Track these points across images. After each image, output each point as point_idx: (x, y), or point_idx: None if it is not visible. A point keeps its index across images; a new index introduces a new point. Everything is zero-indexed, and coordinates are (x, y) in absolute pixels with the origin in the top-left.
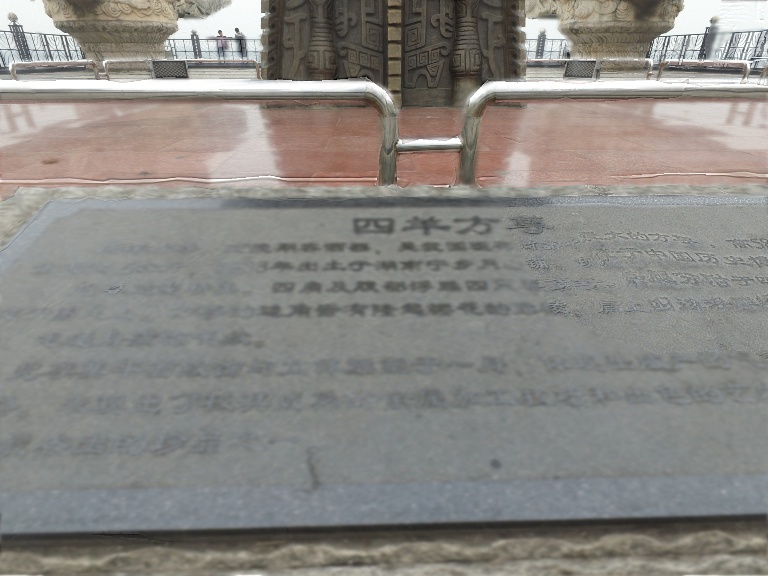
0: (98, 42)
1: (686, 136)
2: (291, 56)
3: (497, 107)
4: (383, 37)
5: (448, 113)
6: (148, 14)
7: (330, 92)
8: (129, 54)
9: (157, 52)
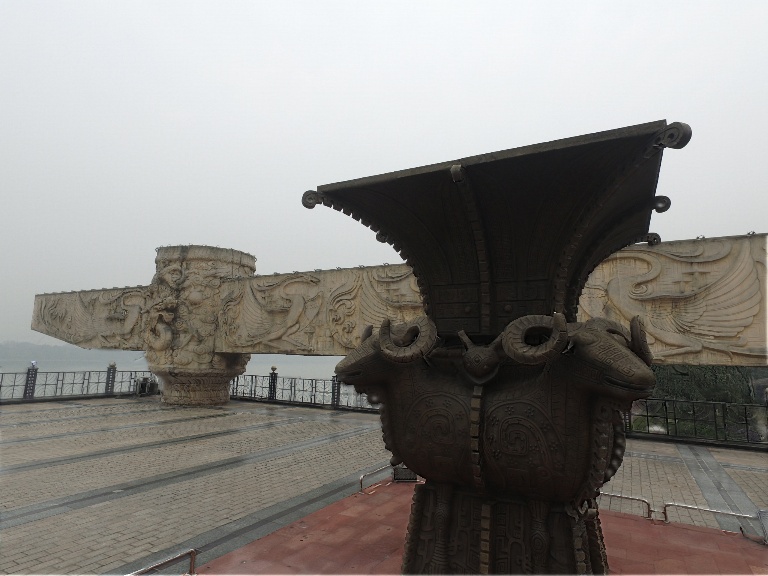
0: None
1: None
2: None
3: None
4: None
5: None
6: None
7: None
8: None
9: None
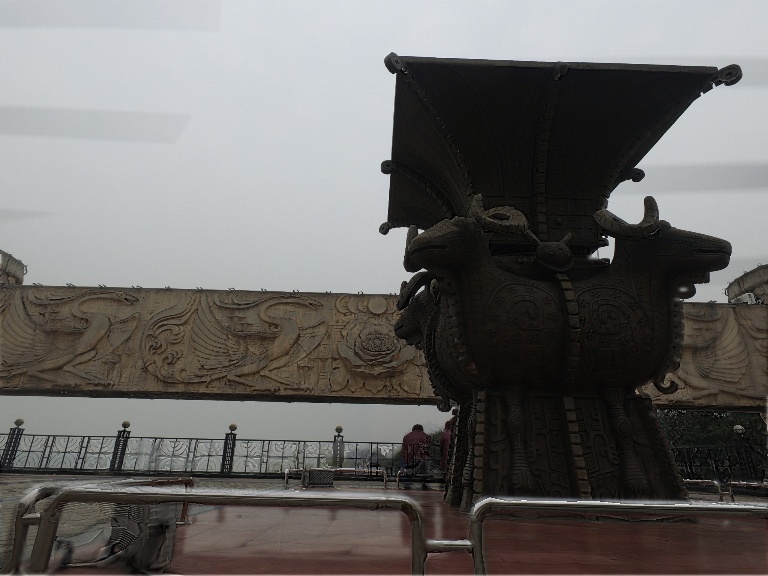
0: None
1: None
2: None
3: None
4: None
5: None
6: None
7: None
8: None
9: None
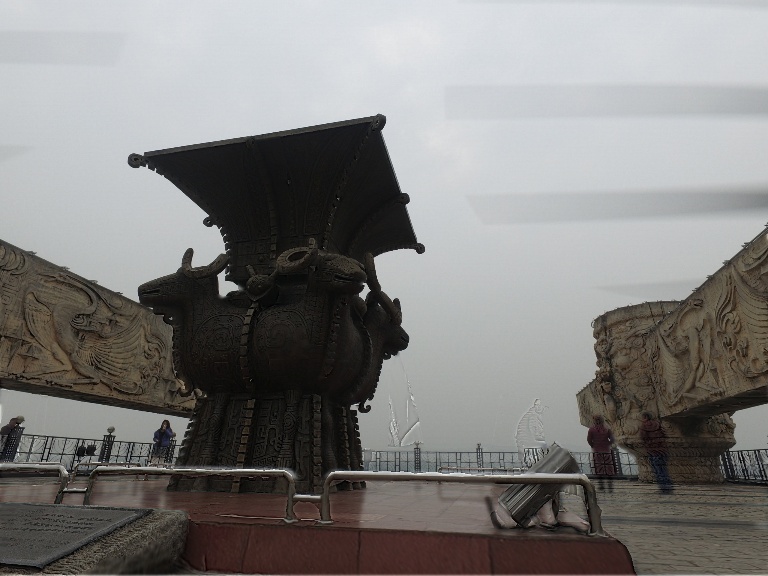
0: None
1: (314, 507)
2: (192, 460)
3: None
4: None
5: None
6: None
7: (48, 469)
8: None
9: None
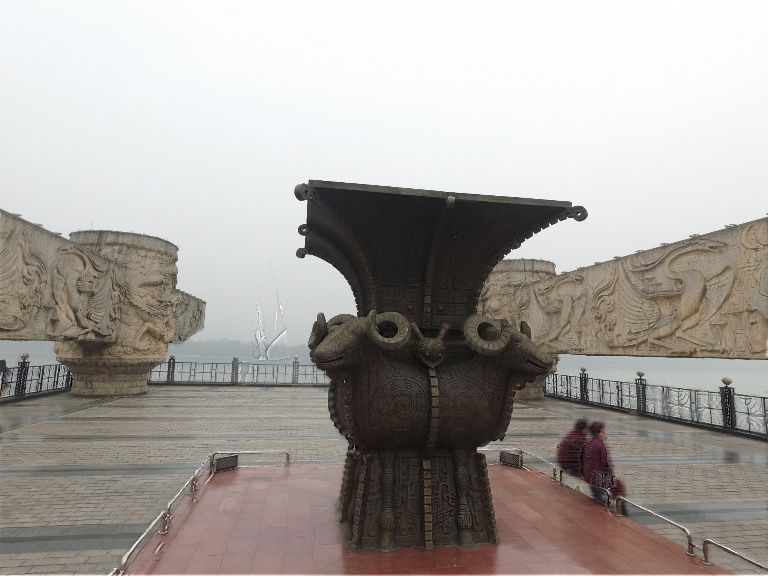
0: (93, 374)
1: None
2: (370, 518)
3: (483, 544)
4: (420, 506)
5: (462, 558)
6: (146, 353)
7: None
8: (118, 383)
9: (142, 380)
